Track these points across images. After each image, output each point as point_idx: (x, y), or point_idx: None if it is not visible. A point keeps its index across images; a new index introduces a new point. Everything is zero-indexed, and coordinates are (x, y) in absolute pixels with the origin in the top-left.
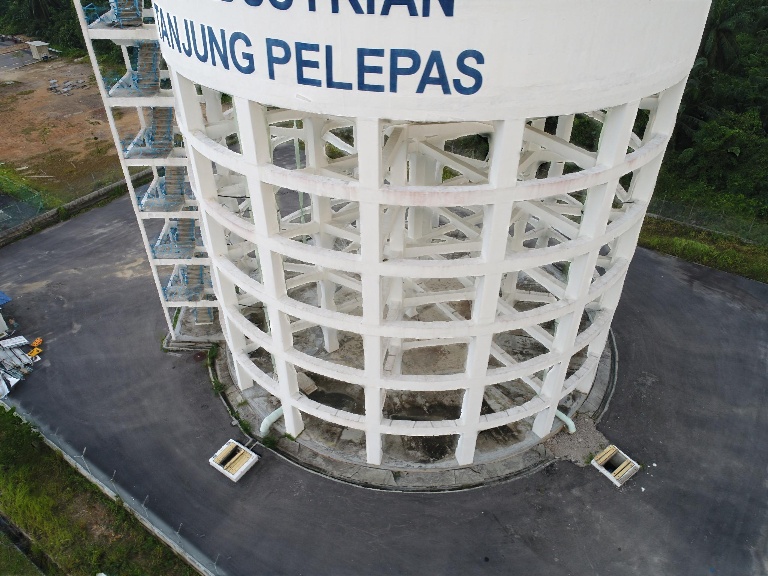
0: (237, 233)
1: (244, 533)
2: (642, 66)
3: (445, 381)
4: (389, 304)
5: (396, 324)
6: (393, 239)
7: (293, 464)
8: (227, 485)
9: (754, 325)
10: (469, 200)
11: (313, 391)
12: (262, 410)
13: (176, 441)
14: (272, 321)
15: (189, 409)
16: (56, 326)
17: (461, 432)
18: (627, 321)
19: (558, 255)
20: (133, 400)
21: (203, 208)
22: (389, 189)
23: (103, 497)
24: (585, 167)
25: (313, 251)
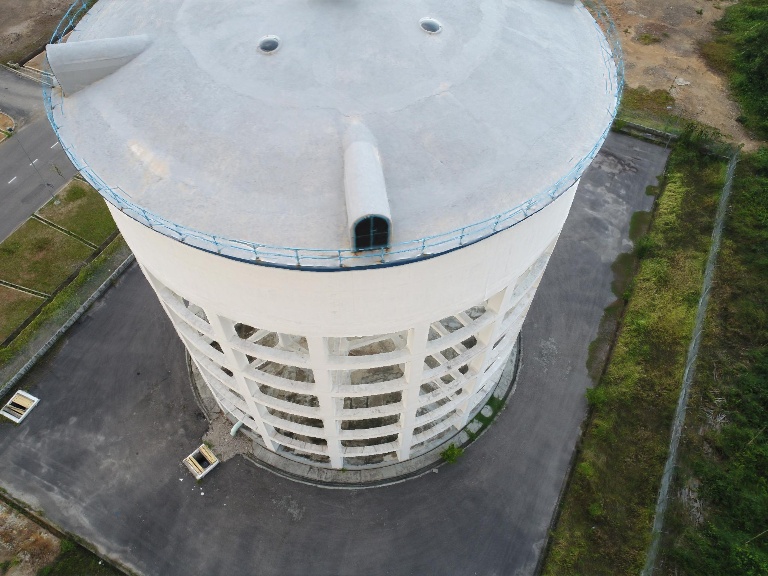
0: None
1: None
2: None
3: None
4: None
5: None
6: None
7: None
8: None
9: None
10: None
11: None
12: None
13: None
14: None
15: None
16: None
17: None
18: (378, 507)
19: None
20: None
21: None
22: None
23: None
24: None
25: None
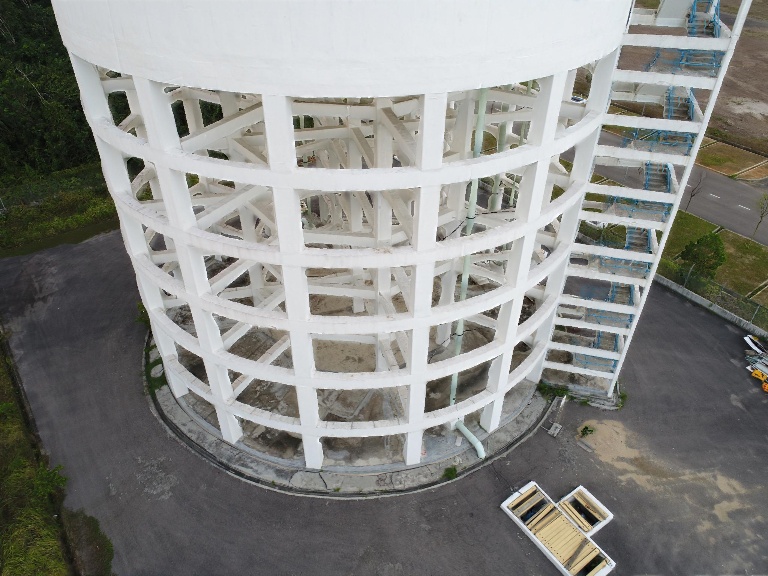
0: None
1: None
2: None
3: None
4: None
5: None
6: None
7: None
8: None
9: (72, 253)
10: None
11: None
12: None
13: None
14: None
15: (572, 290)
16: (765, 409)
17: None
18: None
19: None
20: None
21: None
22: None
23: None
24: None
25: None
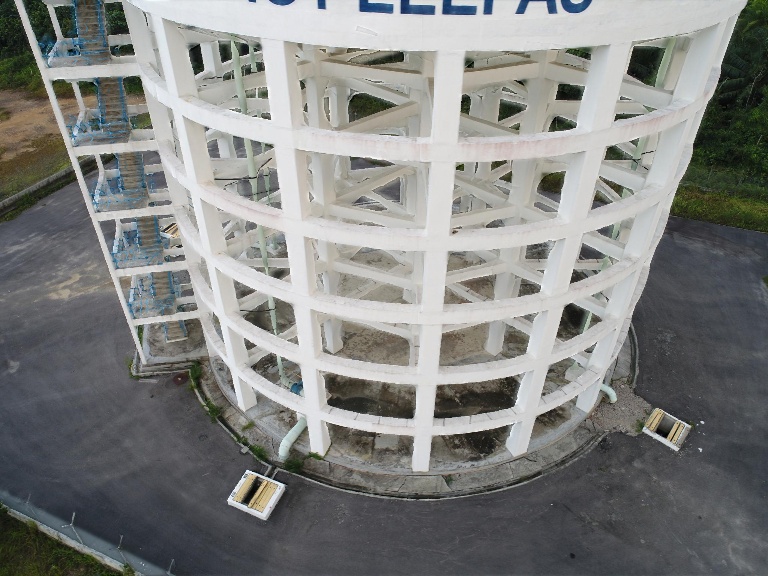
0: (254, 221)
1: None
2: None
3: (510, 366)
4: (412, 289)
5: (461, 308)
6: (420, 213)
7: (327, 487)
8: (256, 526)
9: (742, 269)
10: (561, 148)
11: (328, 399)
12: (275, 430)
13: (179, 484)
14: (300, 324)
15: (184, 443)
16: None
17: (520, 420)
18: None
19: (636, 207)
20: (111, 443)
21: (197, 196)
22: (470, 142)
23: (103, 569)
24: (655, 105)
25: (364, 231)
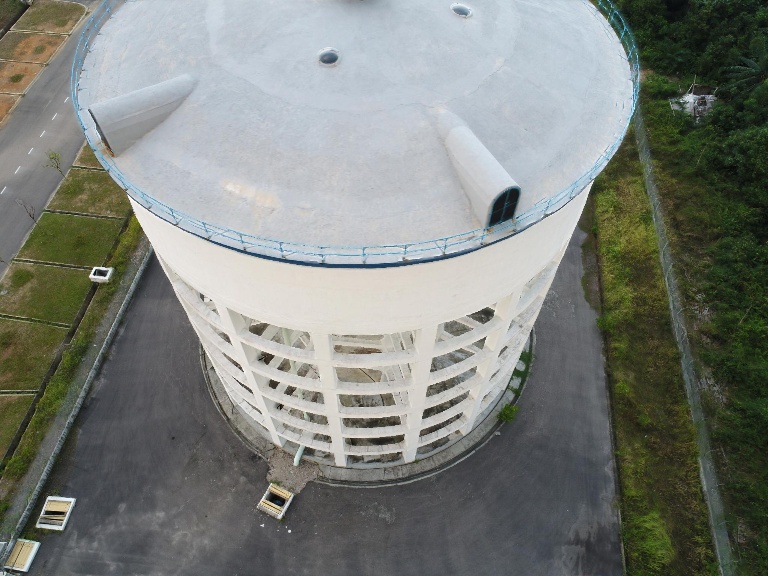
0: None
1: (152, 312)
2: (214, 288)
3: None
4: None
5: None
6: None
7: None
8: None
9: None
10: None
11: None
12: None
13: None
14: None
15: None
16: None
17: None
18: (461, 484)
19: None
20: None
21: None
22: None
23: None
24: None
25: None
